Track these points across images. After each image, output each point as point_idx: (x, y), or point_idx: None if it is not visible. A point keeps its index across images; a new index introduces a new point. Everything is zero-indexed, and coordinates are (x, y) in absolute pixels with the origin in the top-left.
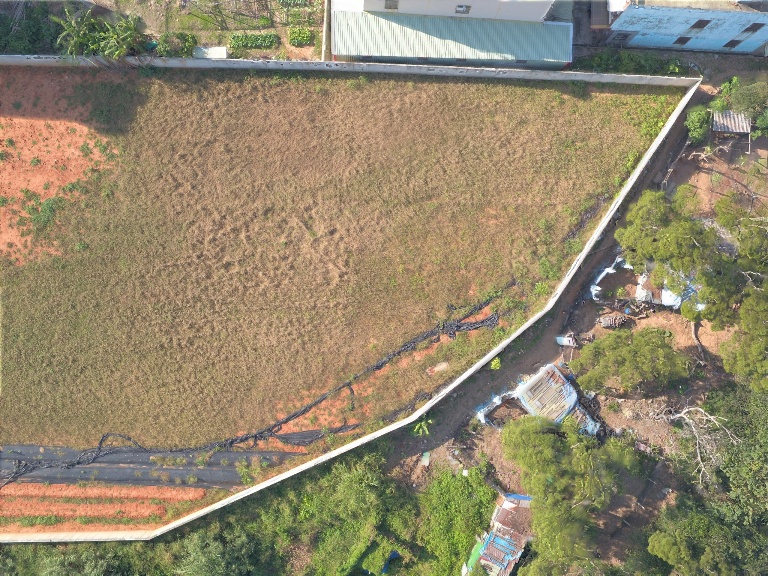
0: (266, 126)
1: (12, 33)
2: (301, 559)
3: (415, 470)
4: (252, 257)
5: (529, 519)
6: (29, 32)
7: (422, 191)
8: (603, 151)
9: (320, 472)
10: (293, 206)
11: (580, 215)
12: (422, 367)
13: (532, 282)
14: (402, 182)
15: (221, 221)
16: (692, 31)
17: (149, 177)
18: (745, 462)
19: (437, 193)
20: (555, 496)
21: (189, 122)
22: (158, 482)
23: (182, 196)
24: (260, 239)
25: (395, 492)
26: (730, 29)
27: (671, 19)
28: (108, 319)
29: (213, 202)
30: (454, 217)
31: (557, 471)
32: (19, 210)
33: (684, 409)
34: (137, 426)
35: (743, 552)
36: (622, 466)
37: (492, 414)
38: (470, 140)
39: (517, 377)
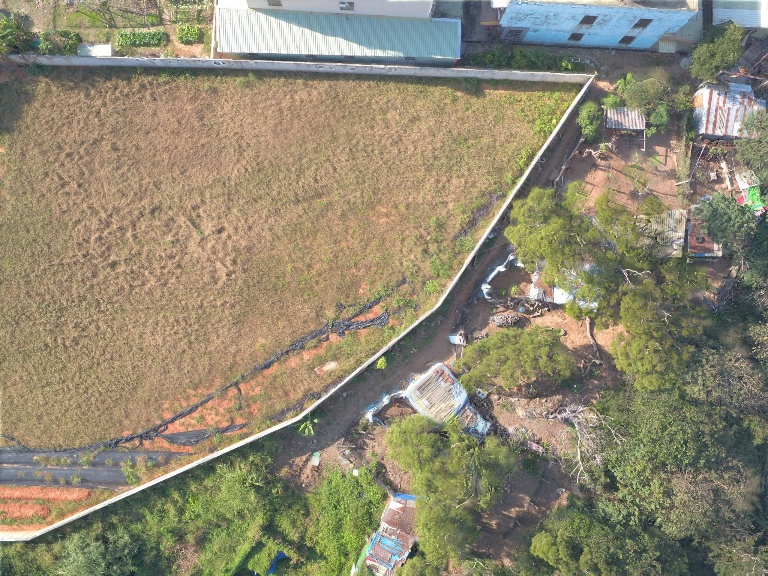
0: (154, 124)
1: None
2: (188, 560)
3: (305, 470)
4: (139, 256)
5: (416, 519)
6: None
7: (311, 189)
8: (496, 148)
9: (205, 472)
10: (180, 204)
11: (472, 213)
12: (310, 366)
13: (423, 280)
14: (291, 180)
15: (108, 220)
16: (582, 27)
17: (35, 176)
18: (630, 461)
19: (327, 191)
20: (437, 496)
21: (76, 120)
22: (42, 482)
23: (68, 195)
24: (147, 238)
25: (282, 492)
26: (619, 25)
27: (557, 15)
28: None
29: (100, 201)
30: (344, 215)
31: (438, 471)
32: None
33: (579, 408)
34: (21, 426)
35: (624, 552)
36: (515, 466)
37: (383, 413)
38: (361, 138)
39: (409, 376)
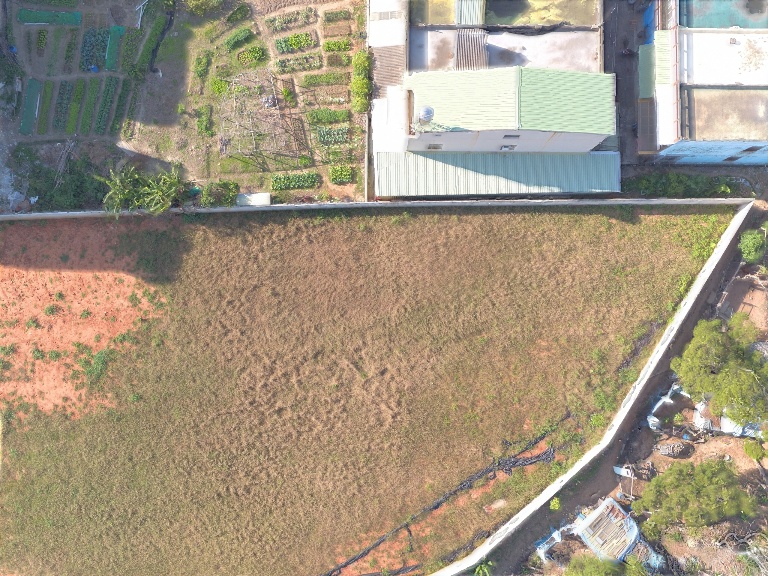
0: (312, 267)
1: (57, 187)
2: None
3: None
4: (304, 401)
5: None
6: (74, 187)
7: (472, 326)
8: (655, 275)
9: None
10: (343, 348)
11: (633, 342)
12: (479, 505)
13: (587, 414)
14: (451, 318)
15: (272, 366)
16: (744, 153)
17: (198, 325)
18: None
19: (487, 327)
20: None
21: (235, 267)
22: None
23: (232, 343)
24: (311, 383)
25: None
26: None
27: (723, 147)
28: (164, 470)
29: (263, 347)
30: (505, 351)
31: None
32: (72, 364)
33: (747, 534)
34: None
35: None
36: None
37: None
38: (518, 271)
39: (575, 509)
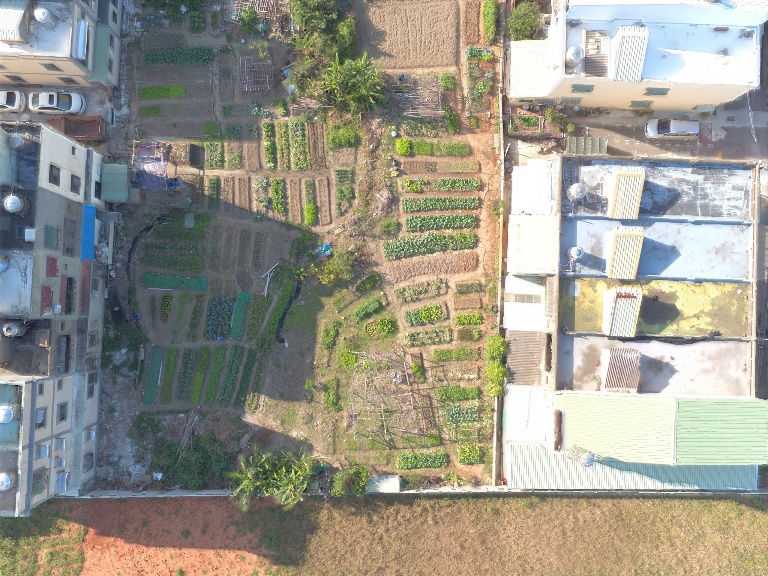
0: (437, 549)
1: (179, 461)
2: None
3: None
4: None
5: None
6: (198, 465)
7: None
8: None
9: None
10: None
11: None
12: None
13: None
14: None
15: None
16: None
17: None
18: None
19: None
20: None
21: (359, 548)
22: None
23: None
24: None
25: None
26: None
27: None
28: None
29: None
30: None
31: None
32: None
33: None
34: None
35: None
36: None
37: None
38: (645, 558)
39: None
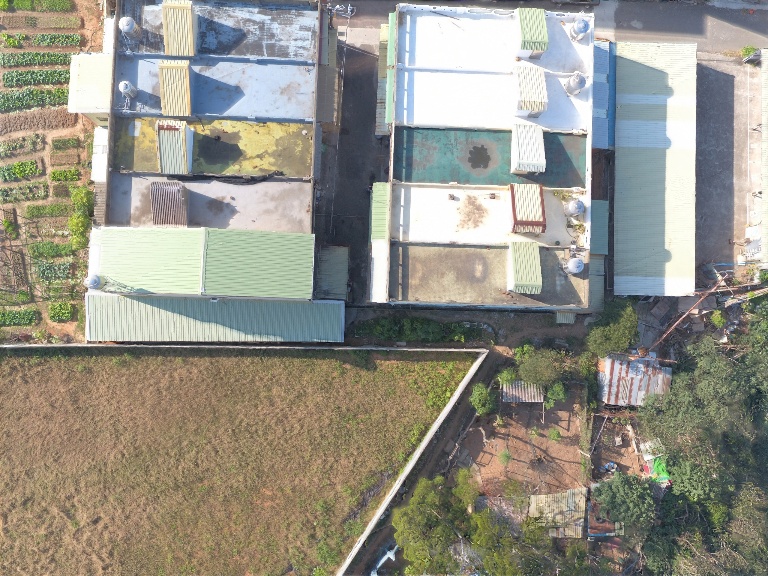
0: (26, 409)
1: None
2: None
3: None
4: (10, 550)
5: None
6: None
7: (192, 474)
8: (387, 424)
9: None
10: (54, 495)
11: (362, 493)
12: None
13: (310, 567)
14: (171, 465)
15: None
16: None
17: None
18: None
19: (208, 476)
20: None
21: None
22: None
23: None
24: (19, 531)
25: None
26: None
27: None
28: None
29: None
30: (226, 500)
31: None
32: None
33: None
34: None
35: None
36: None
37: None
38: (244, 417)
39: None
